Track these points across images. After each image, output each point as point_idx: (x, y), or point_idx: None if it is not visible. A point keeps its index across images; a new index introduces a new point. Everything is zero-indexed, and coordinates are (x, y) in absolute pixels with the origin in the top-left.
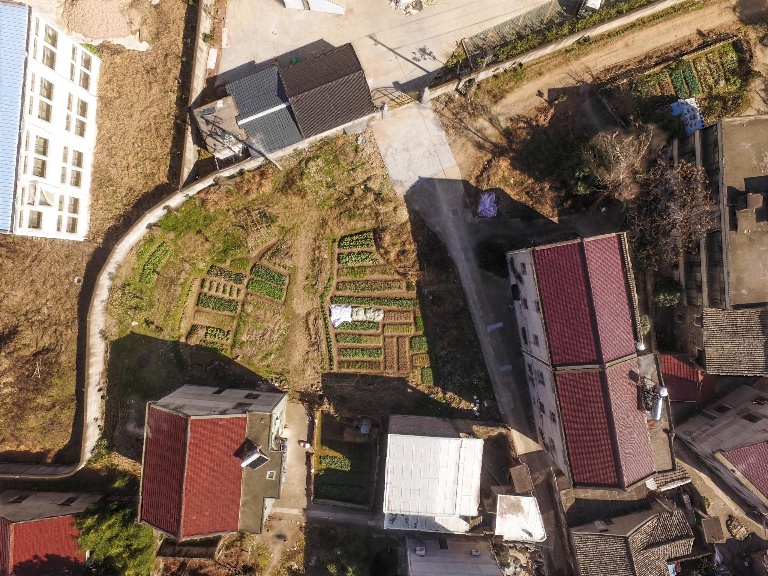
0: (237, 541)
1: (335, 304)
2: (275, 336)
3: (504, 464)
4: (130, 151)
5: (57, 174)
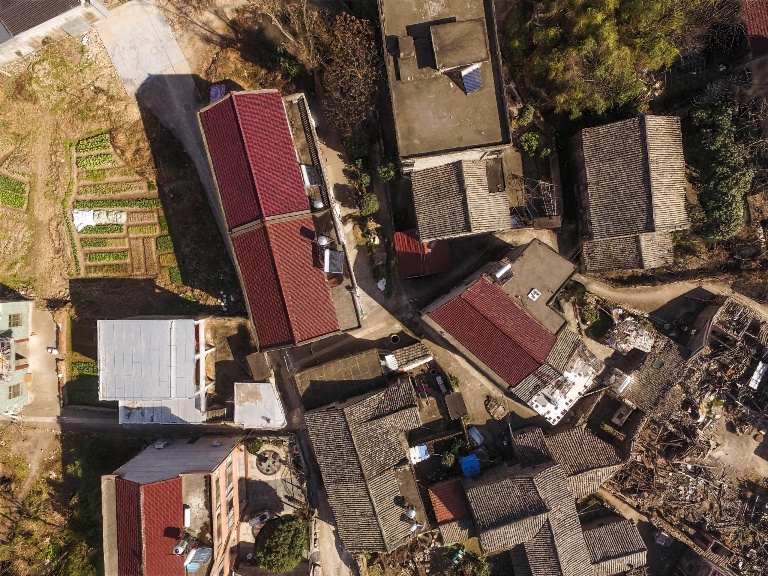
0: None
1: (77, 209)
2: (19, 245)
3: None
4: None
5: None
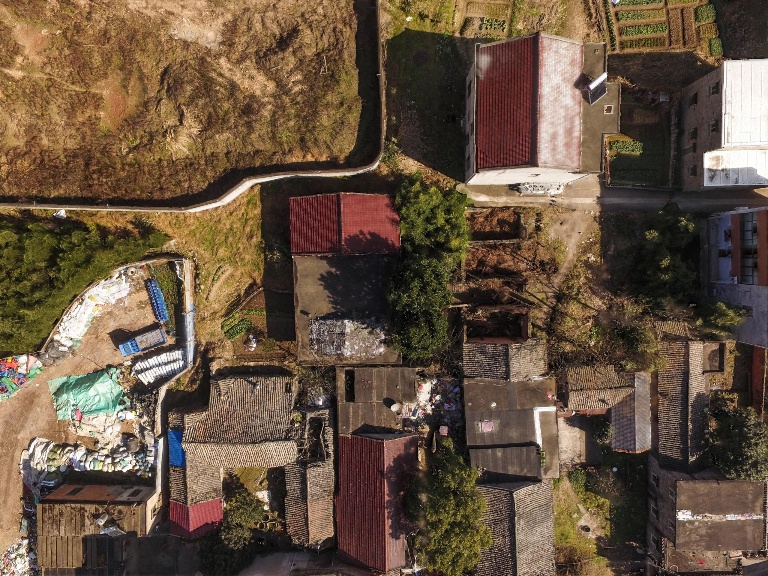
0: (534, 233)
1: None
2: (553, 20)
3: None
4: None
5: None
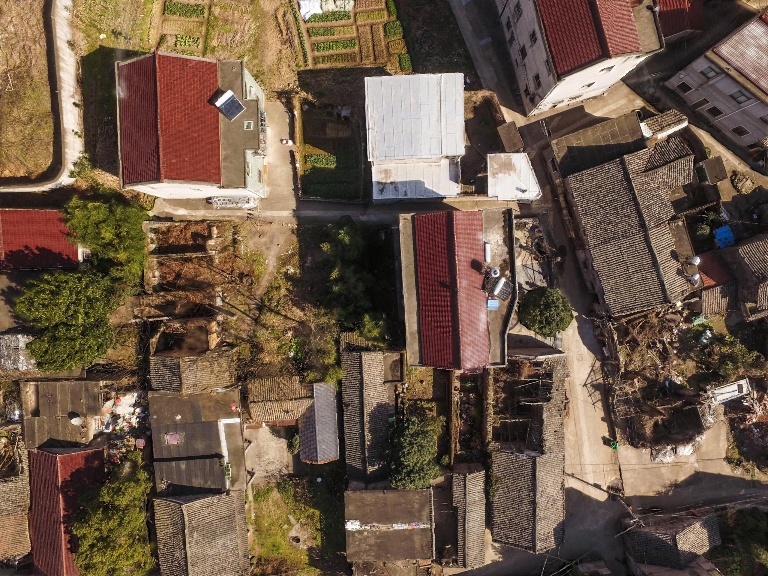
0: (230, 246)
1: None
2: (246, 37)
3: (493, 142)
4: None
5: None
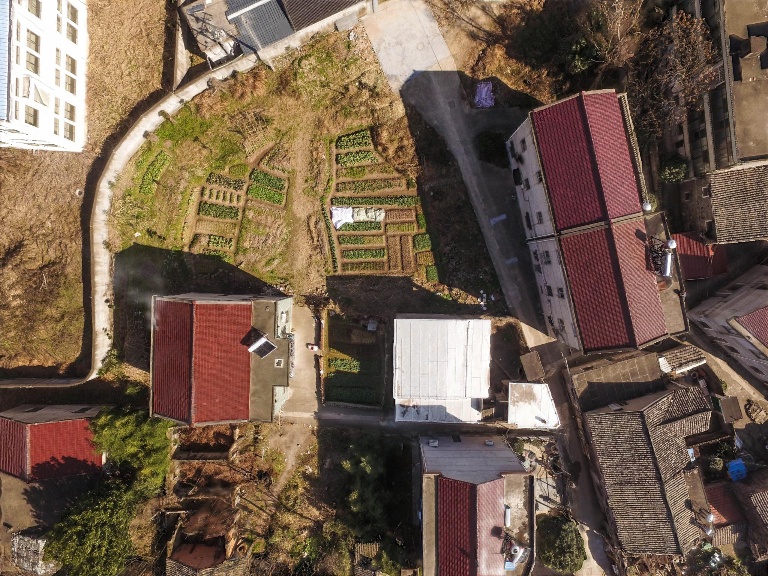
0: (250, 446)
1: (336, 206)
2: (277, 241)
3: (514, 358)
4: (123, 60)
5: (51, 75)
